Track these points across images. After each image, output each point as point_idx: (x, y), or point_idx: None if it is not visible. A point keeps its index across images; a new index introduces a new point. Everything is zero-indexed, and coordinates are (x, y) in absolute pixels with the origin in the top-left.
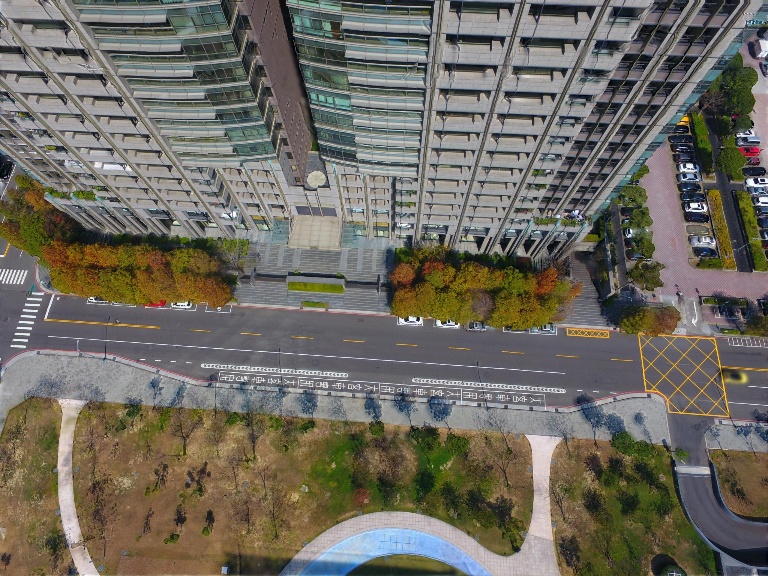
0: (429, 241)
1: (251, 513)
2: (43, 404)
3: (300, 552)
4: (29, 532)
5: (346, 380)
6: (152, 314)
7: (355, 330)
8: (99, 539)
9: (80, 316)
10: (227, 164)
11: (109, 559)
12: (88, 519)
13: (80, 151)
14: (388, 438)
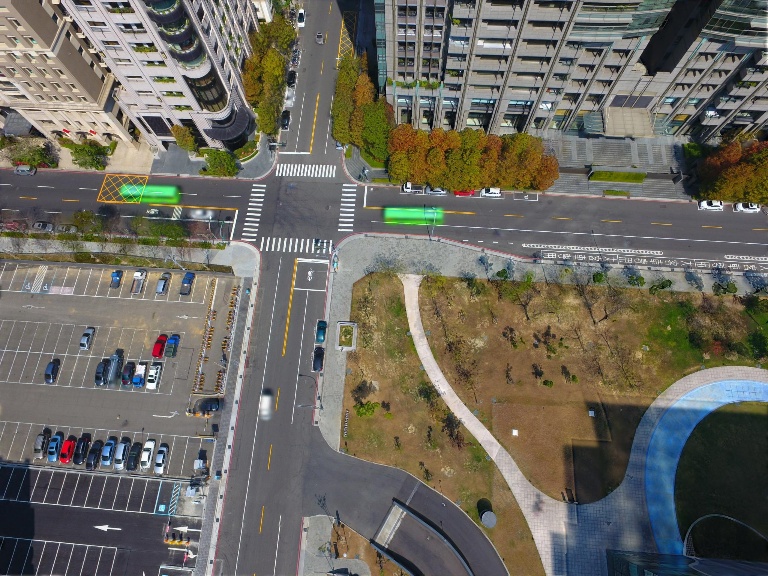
0: (712, 138)
1: (602, 368)
2: (384, 278)
3: (657, 399)
4: (401, 384)
5: (662, 257)
6: (464, 202)
7: (660, 215)
8: (468, 389)
9: (397, 204)
10: (611, 38)
11: (482, 405)
12: (453, 373)
13: (481, 25)
14: (714, 305)
